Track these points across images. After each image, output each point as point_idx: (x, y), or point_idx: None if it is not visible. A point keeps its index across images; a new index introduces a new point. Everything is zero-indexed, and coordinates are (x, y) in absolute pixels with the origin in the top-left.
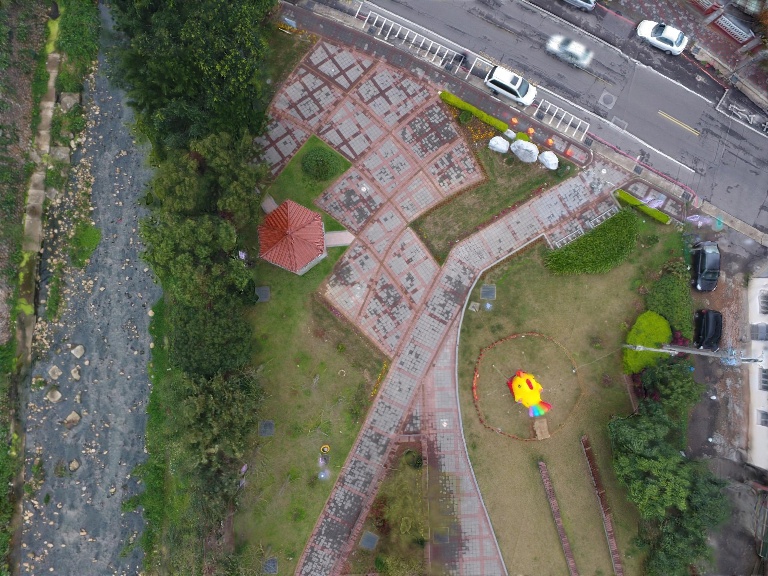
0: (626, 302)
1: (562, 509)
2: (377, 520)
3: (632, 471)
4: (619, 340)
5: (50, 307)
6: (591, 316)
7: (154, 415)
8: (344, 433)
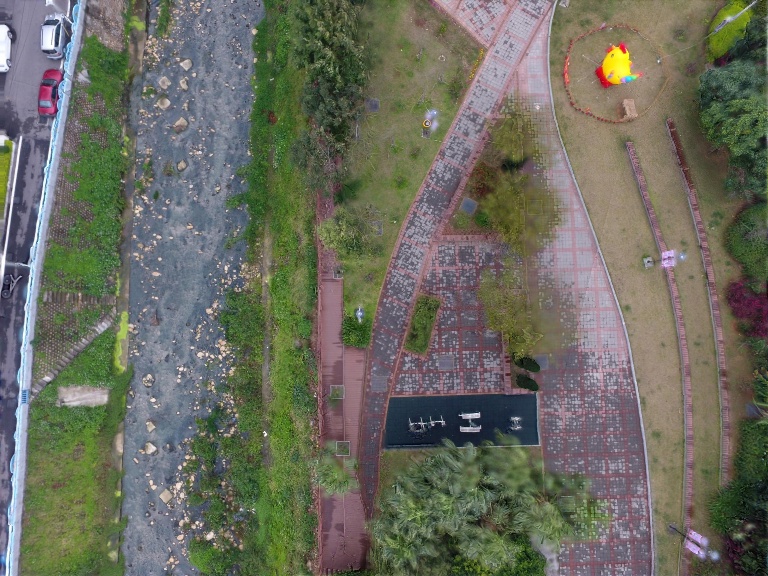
0: (706, 2)
1: (649, 185)
2: (477, 184)
3: (723, 117)
4: (700, 34)
5: (161, 22)
6: (674, 12)
7: (258, 119)
8: (444, 112)
